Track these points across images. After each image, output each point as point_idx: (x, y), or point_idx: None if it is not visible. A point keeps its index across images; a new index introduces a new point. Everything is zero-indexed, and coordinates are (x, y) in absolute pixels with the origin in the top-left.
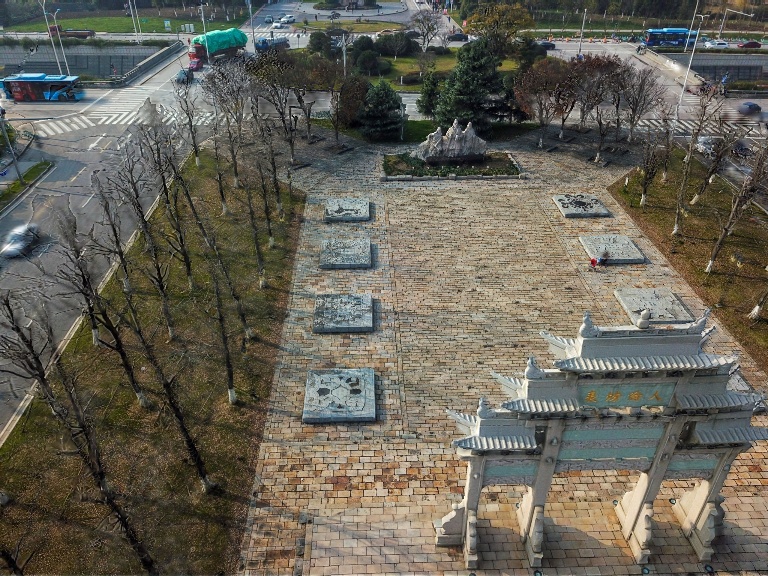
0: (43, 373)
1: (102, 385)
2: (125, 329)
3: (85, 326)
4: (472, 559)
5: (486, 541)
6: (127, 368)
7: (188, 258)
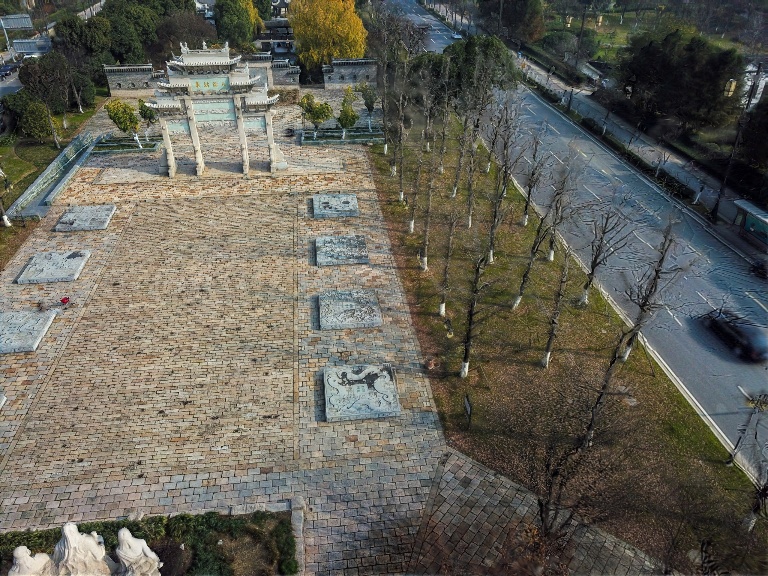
0: None
1: (491, 204)
2: (514, 232)
3: None
4: None
5: (265, 167)
6: None
7: (491, 231)
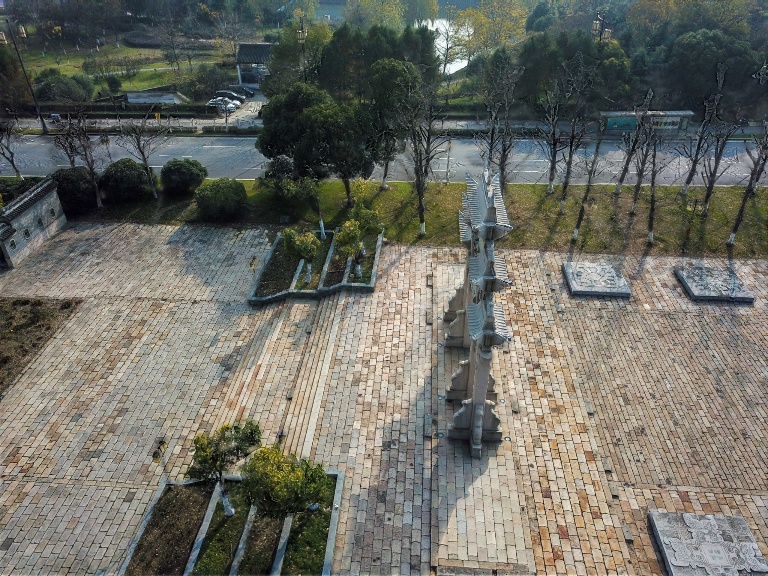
0: (555, 163)
1: (575, 198)
2: None
3: (617, 176)
4: (445, 310)
5: None
6: (566, 181)
7: (711, 187)
